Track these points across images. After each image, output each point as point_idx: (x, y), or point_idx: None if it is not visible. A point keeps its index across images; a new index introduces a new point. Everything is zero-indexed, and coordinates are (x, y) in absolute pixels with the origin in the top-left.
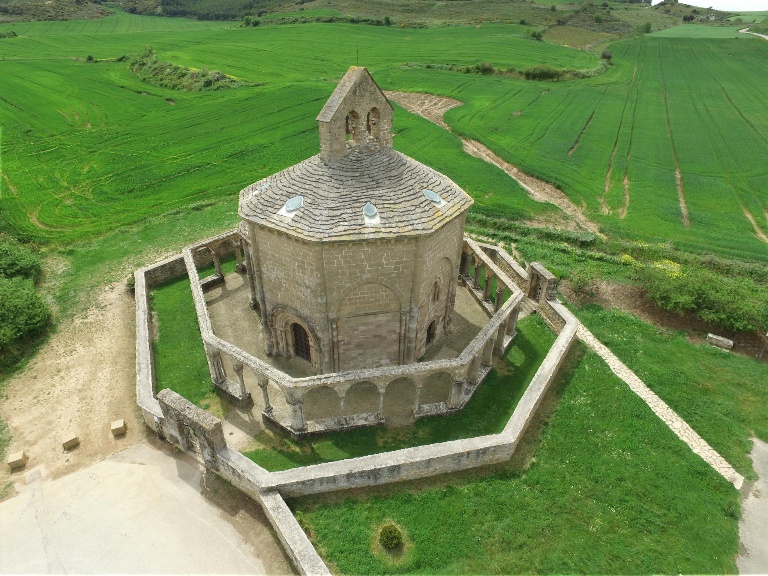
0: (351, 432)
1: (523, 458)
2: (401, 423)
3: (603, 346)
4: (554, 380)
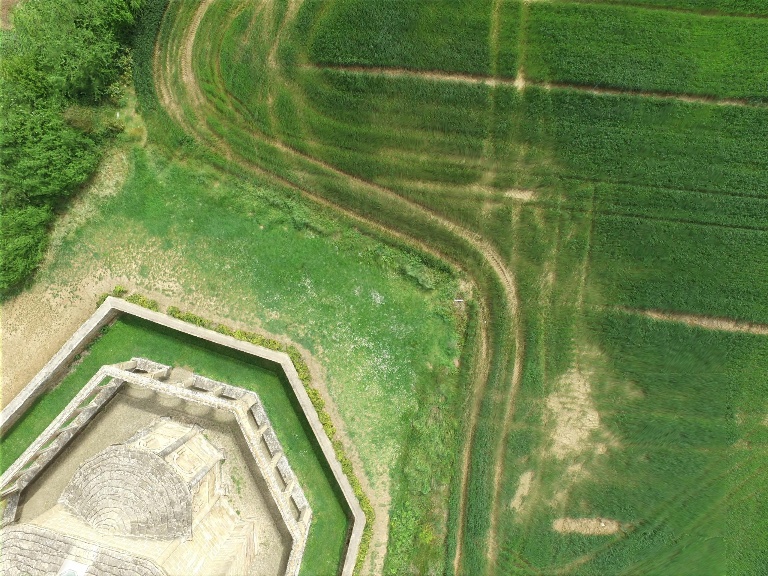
0: None
1: None
2: None
3: None
4: None
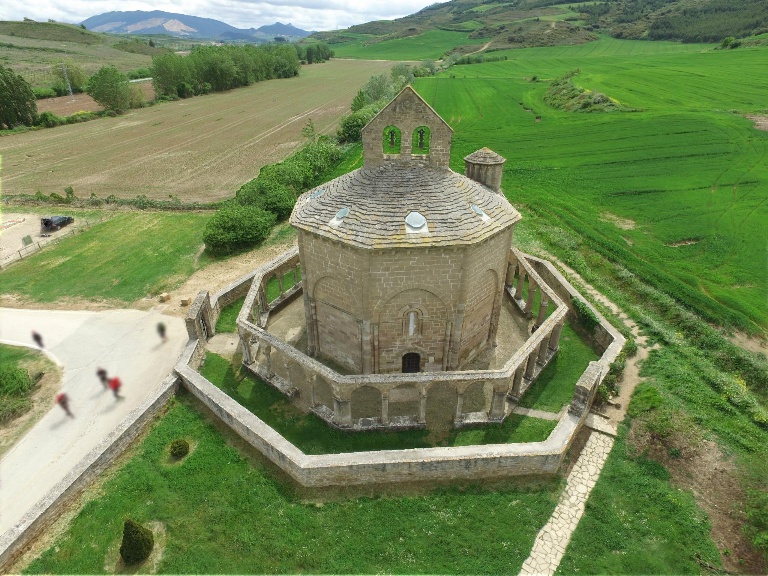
0: (269, 387)
1: (316, 496)
2: (302, 407)
3: (581, 506)
4: (455, 480)
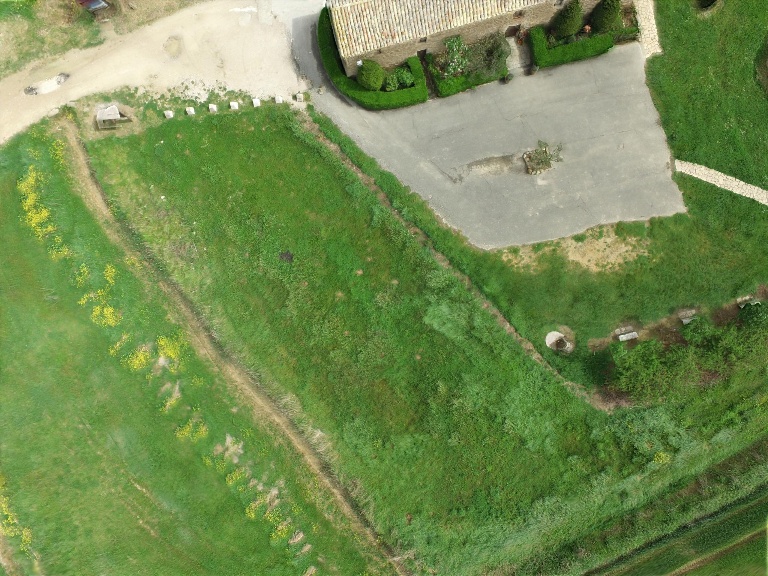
0: None
1: (762, 73)
2: None
3: None
4: None
